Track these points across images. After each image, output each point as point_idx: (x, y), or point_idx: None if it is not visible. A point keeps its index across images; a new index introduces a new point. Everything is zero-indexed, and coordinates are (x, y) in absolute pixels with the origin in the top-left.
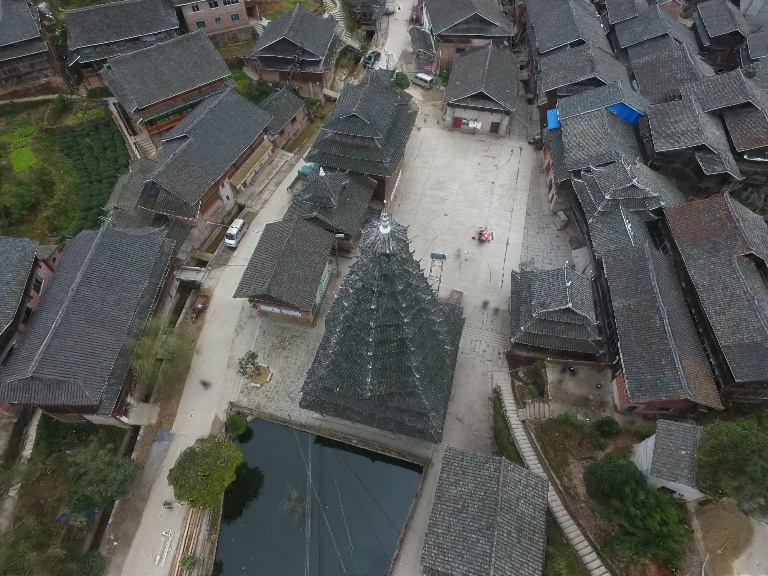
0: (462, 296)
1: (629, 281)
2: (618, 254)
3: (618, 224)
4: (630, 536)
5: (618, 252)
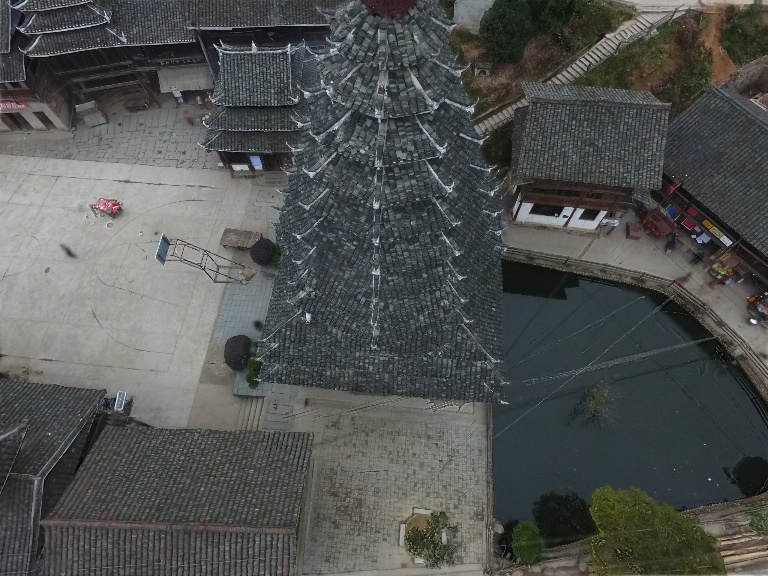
0: (233, 229)
1: (243, 2)
2: (196, 8)
3: (139, 6)
4: (574, 3)
5: (193, 8)
